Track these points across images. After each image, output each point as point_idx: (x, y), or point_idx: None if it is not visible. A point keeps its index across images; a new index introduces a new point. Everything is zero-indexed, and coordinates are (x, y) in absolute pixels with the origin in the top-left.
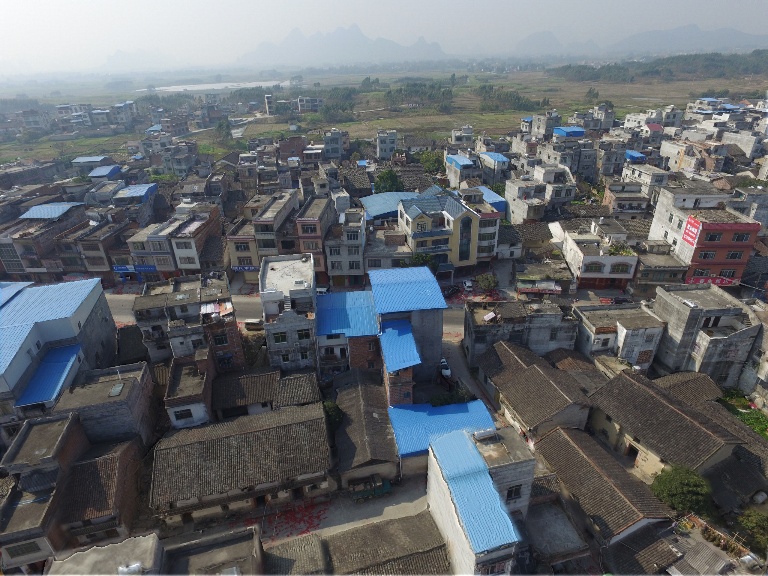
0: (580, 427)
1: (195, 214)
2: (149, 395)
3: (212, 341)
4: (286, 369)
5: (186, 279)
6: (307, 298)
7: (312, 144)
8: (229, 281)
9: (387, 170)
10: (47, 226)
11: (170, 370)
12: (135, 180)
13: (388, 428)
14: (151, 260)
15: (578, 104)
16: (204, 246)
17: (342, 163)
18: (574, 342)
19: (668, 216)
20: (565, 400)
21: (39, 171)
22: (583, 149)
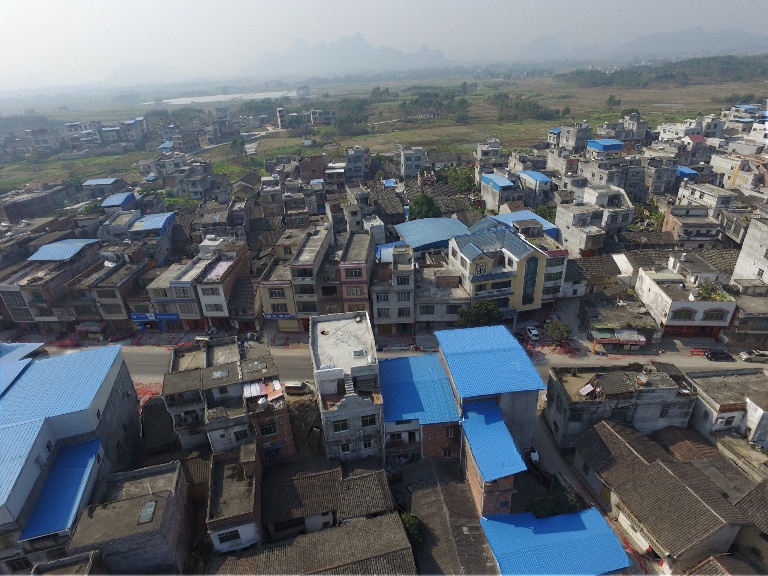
0: (726, 545)
1: (221, 253)
2: (184, 503)
3: (258, 432)
4: (346, 460)
5: (219, 342)
6: (371, 375)
7: (333, 162)
8: (260, 329)
9: (423, 194)
10: (58, 268)
11: (210, 474)
12: (150, 208)
13: (485, 550)
14: (174, 308)
15: (599, 112)
16: (232, 290)
17: (367, 183)
18: (687, 418)
19: (763, 252)
20: (715, 518)
21: None
22: (630, 166)
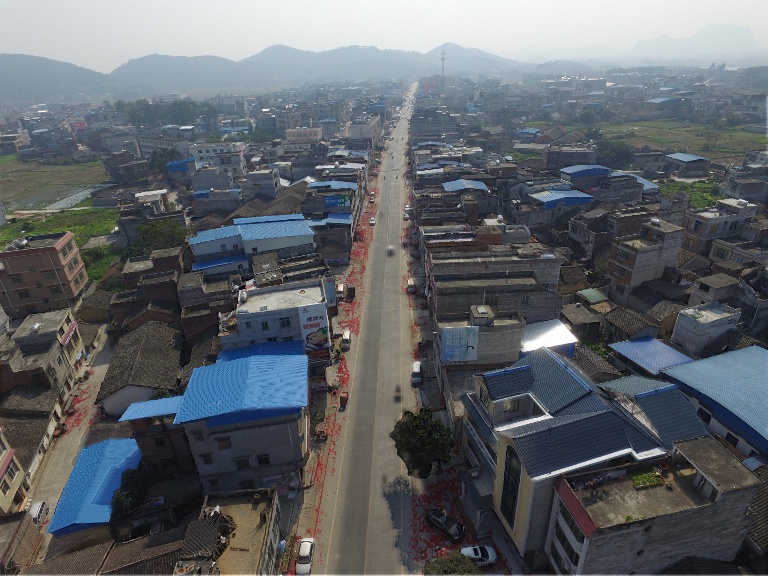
0: None
1: None
2: None
3: None
4: None
5: None
6: None
7: None
8: None
9: None
10: (446, 196)
11: None
12: (604, 188)
13: None
14: None
15: None
16: None
17: None
18: None
19: None
20: None
21: (591, 156)
22: None
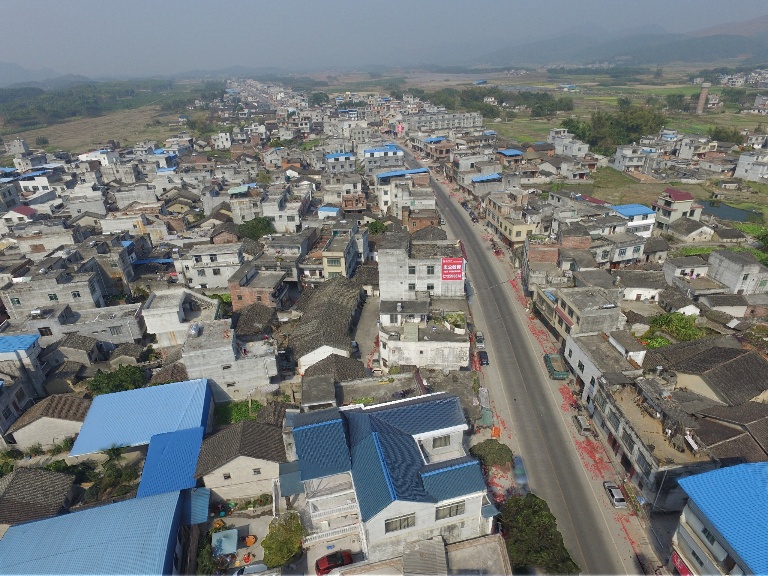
0: None
1: None
2: None
3: None
4: None
5: None
6: None
7: None
8: None
9: None
10: None
11: None
12: None
13: None
14: None
15: None
16: None
17: None
18: None
19: (407, 270)
20: None
21: None
22: None
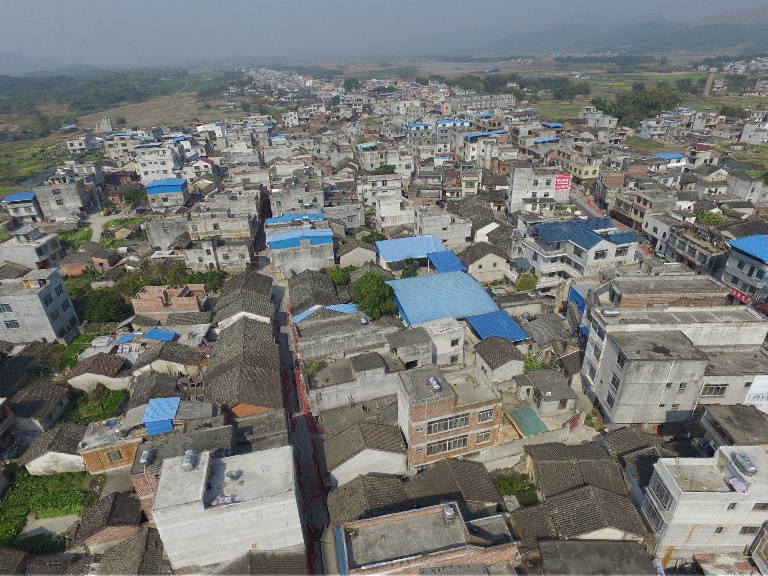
0: None
1: None
2: None
3: None
4: None
5: None
6: None
7: None
8: None
9: (373, 273)
10: None
11: None
12: None
13: None
14: None
15: None
16: None
17: (97, 373)
18: None
19: (533, 183)
20: None
21: None
22: None
